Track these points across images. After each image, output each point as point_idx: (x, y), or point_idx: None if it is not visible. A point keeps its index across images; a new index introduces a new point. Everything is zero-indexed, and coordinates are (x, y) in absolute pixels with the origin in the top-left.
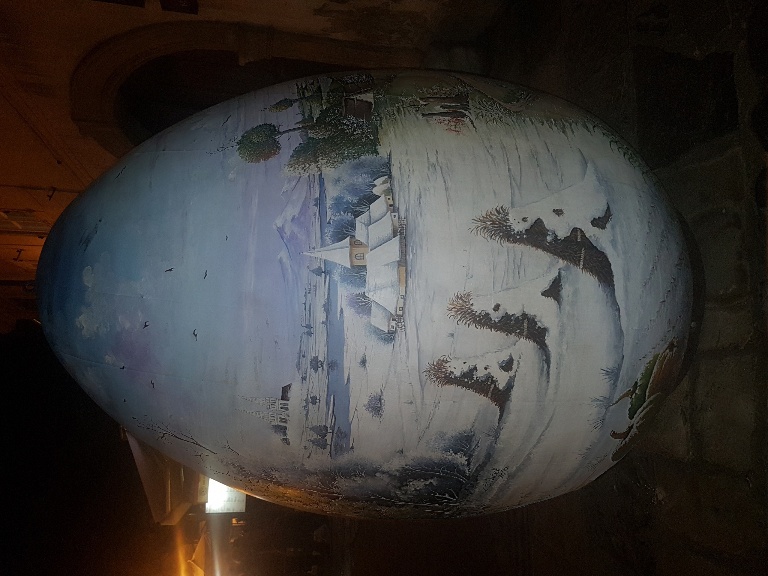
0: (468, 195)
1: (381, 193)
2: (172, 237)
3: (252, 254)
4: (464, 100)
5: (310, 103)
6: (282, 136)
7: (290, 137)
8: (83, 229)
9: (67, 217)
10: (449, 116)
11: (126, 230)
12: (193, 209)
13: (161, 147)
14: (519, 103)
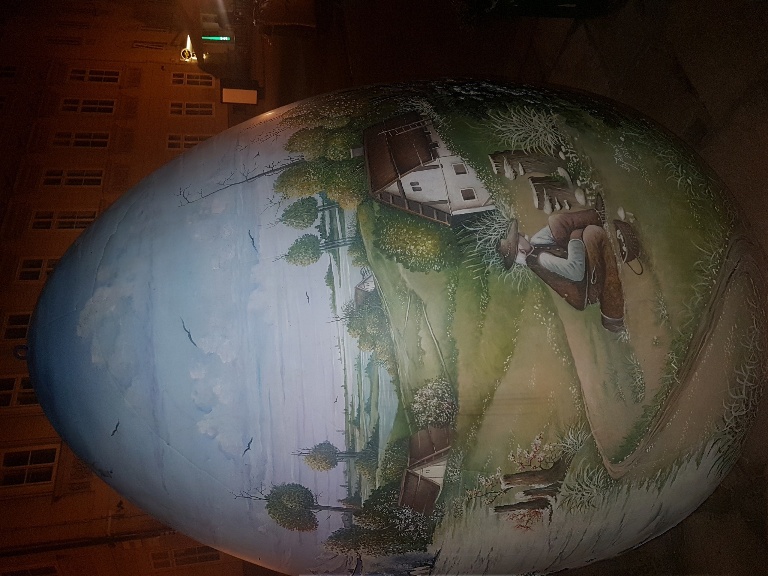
0: (505, 571)
1: (418, 574)
2: (202, 534)
3: (285, 570)
4: (560, 475)
5: (360, 472)
6: (320, 513)
7: (330, 516)
8: (91, 458)
9: (57, 406)
10: (527, 509)
11: (147, 500)
12: (221, 532)
13: (162, 432)
14: (634, 454)
